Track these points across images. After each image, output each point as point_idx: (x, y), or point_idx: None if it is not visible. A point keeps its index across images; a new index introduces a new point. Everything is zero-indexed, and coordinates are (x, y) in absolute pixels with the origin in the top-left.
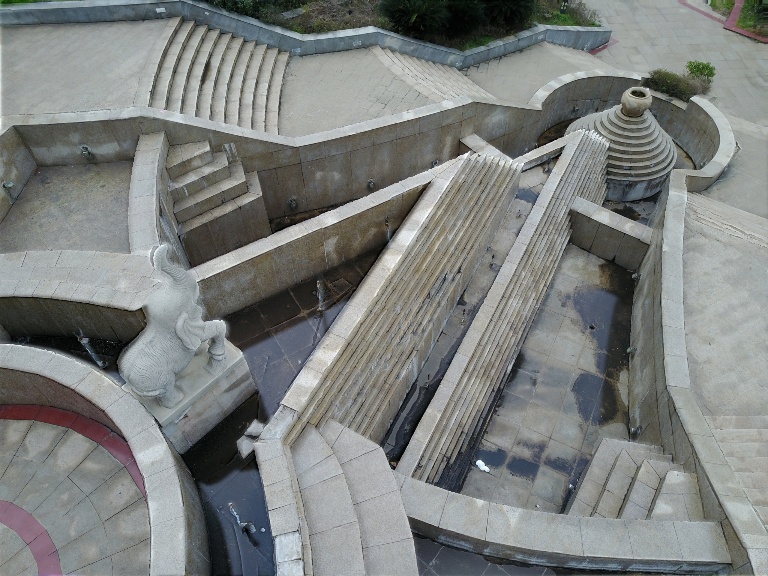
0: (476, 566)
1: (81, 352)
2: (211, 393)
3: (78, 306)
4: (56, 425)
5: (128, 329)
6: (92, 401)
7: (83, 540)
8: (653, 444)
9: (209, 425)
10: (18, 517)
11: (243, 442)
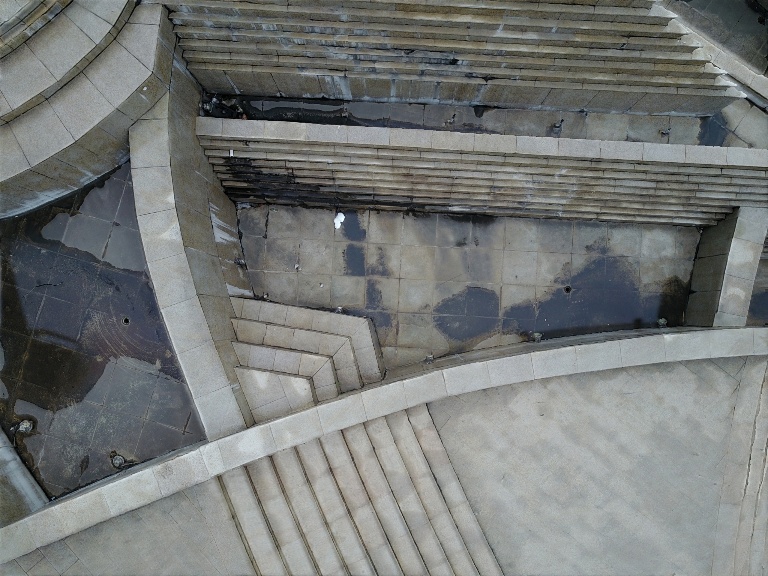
0: None
1: None
2: None
3: None
4: None
5: None
6: None
7: None
8: (396, 374)
9: None
10: None
11: None
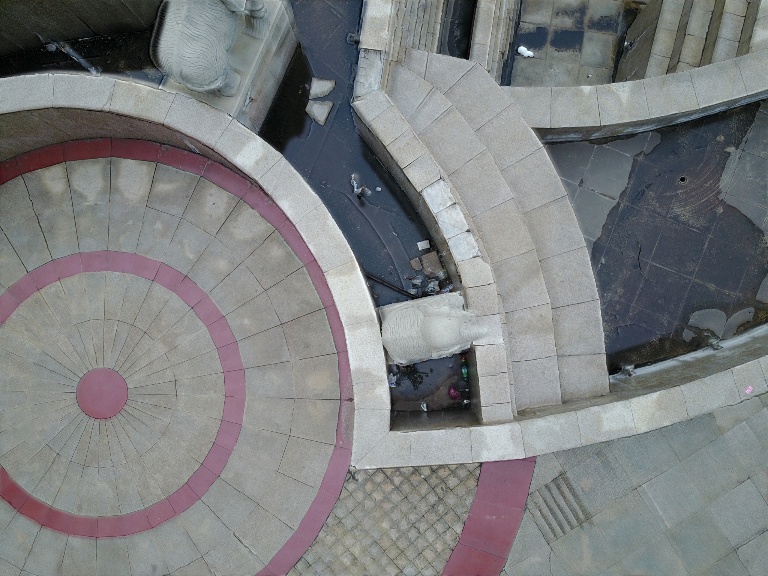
0: (583, 153)
1: (57, 64)
2: (263, 62)
3: (26, 1)
4: (94, 159)
5: (103, 14)
6: (141, 118)
7: (206, 258)
8: None
9: (267, 101)
10: (124, 261)
11: (313, 108)
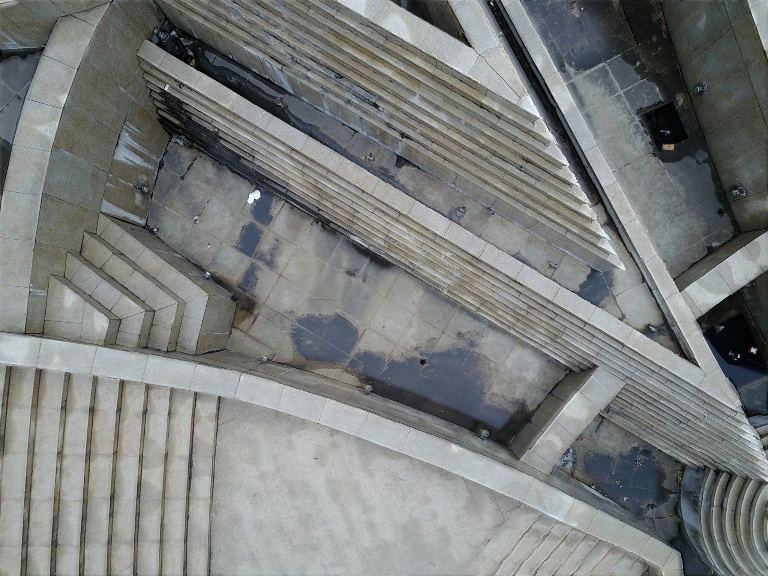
0: None
1: None
2: None
3: None
4: None
5: None
6: None
7: None
8: None
9: None
10: None
11: None
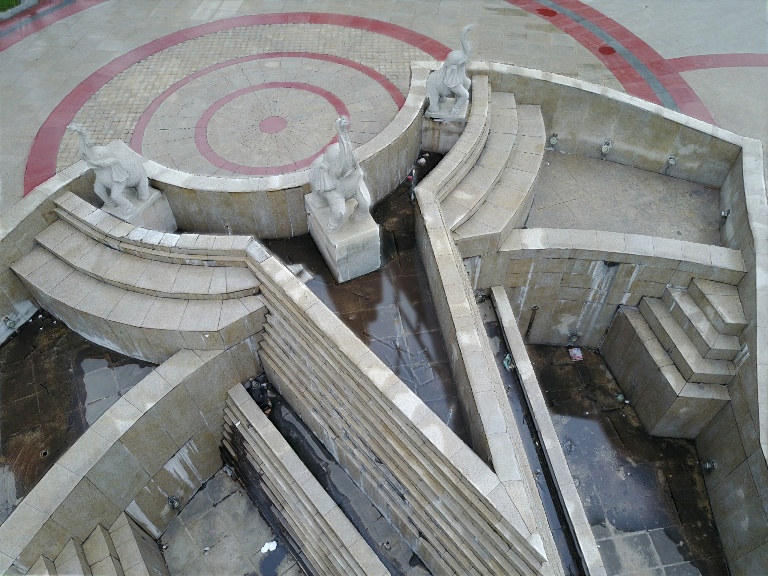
0: None
1: None
2: None
3: None
4: None
5: None
6: None
7: None
8: None
9: None
10: None
11: (298, 267)
